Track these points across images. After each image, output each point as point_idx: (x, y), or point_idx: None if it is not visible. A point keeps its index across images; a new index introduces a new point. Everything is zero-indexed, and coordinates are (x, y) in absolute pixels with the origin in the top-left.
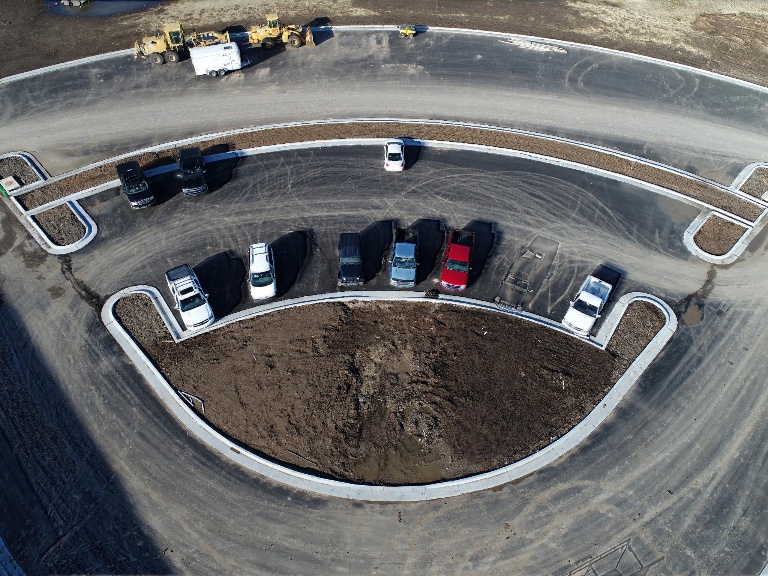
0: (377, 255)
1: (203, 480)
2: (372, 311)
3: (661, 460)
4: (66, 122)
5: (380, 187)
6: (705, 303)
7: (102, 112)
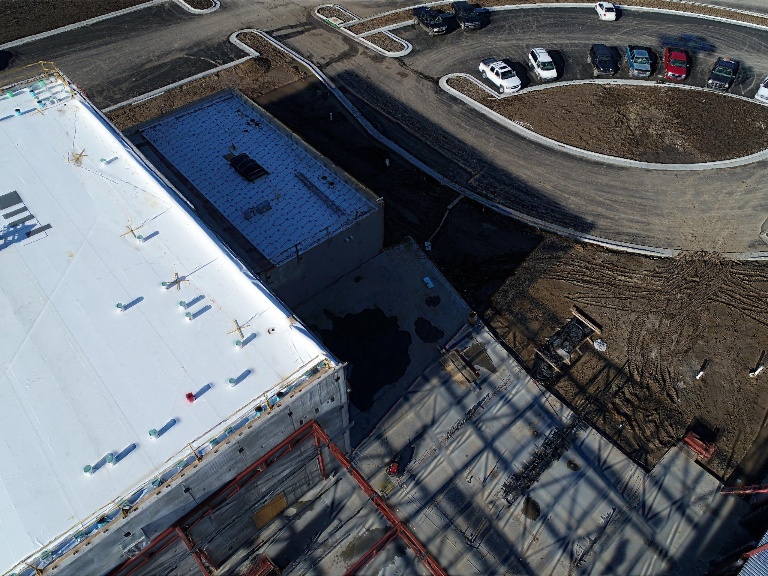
0: (614, 63)
1: (547, 157)
2: (622, 89)
3: None
4: None
5: (601, 29)
6: None
7: None
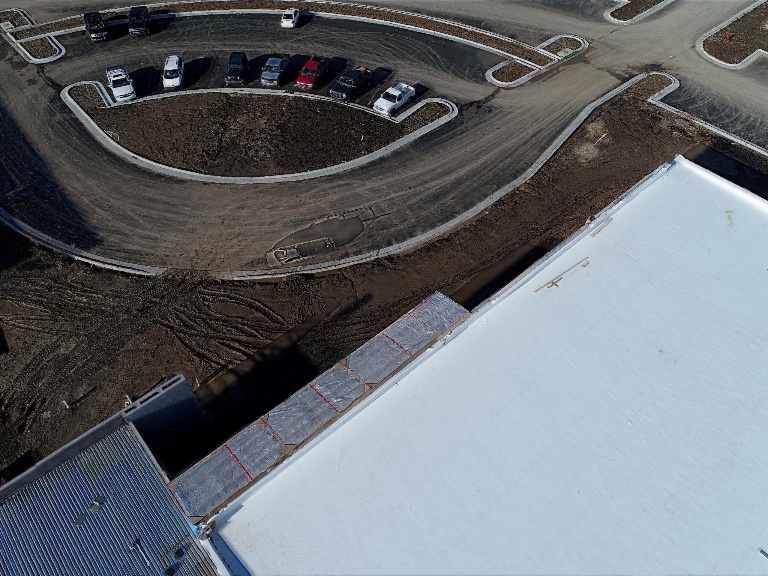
0: (259, 71)
1: (111, 169)
2: (246, 99)
3: (411, 174)
4: None
5: (275, 37)
6: (483, 106)
7: None
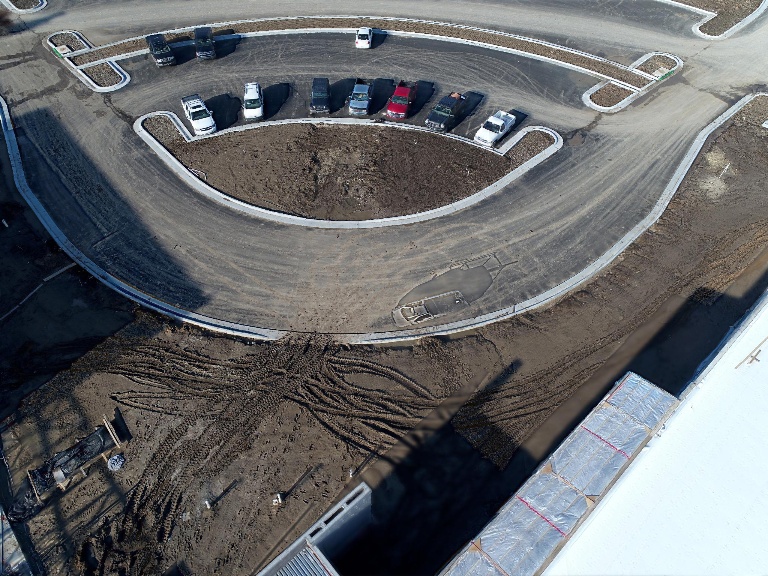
0: (342, 98)
1: (203, 213)
2: (334, 129)
3: (529, 215)
4: (106, 12)
5: (350, 59)
6: (588, 134)
7: (135, 6)
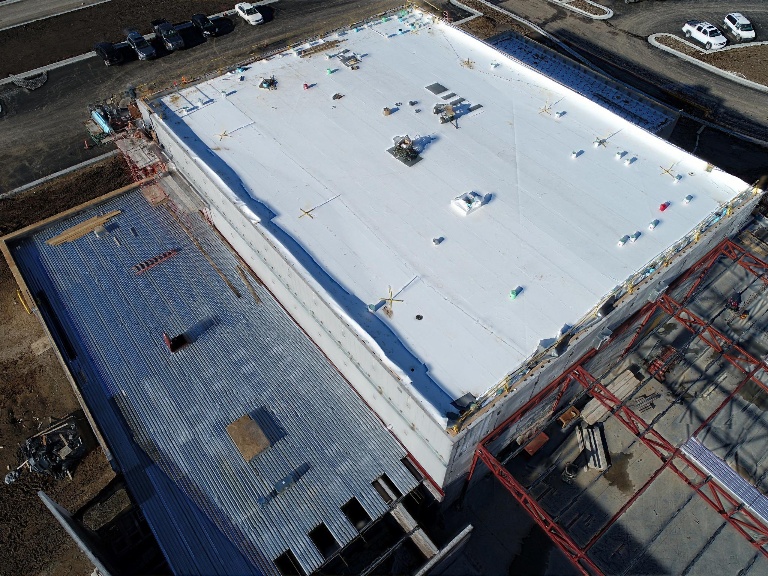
0: None
1: (766, 99)
2: None
3: None
4: None
5: None
6: None
7: None
